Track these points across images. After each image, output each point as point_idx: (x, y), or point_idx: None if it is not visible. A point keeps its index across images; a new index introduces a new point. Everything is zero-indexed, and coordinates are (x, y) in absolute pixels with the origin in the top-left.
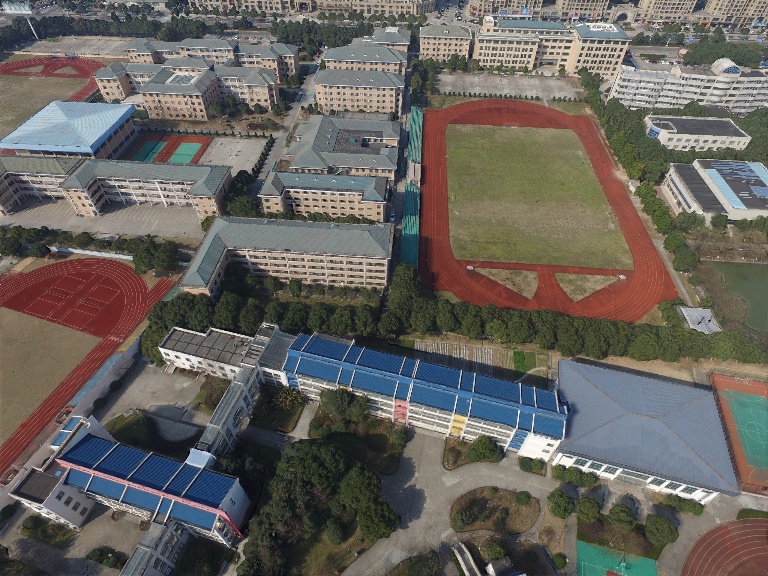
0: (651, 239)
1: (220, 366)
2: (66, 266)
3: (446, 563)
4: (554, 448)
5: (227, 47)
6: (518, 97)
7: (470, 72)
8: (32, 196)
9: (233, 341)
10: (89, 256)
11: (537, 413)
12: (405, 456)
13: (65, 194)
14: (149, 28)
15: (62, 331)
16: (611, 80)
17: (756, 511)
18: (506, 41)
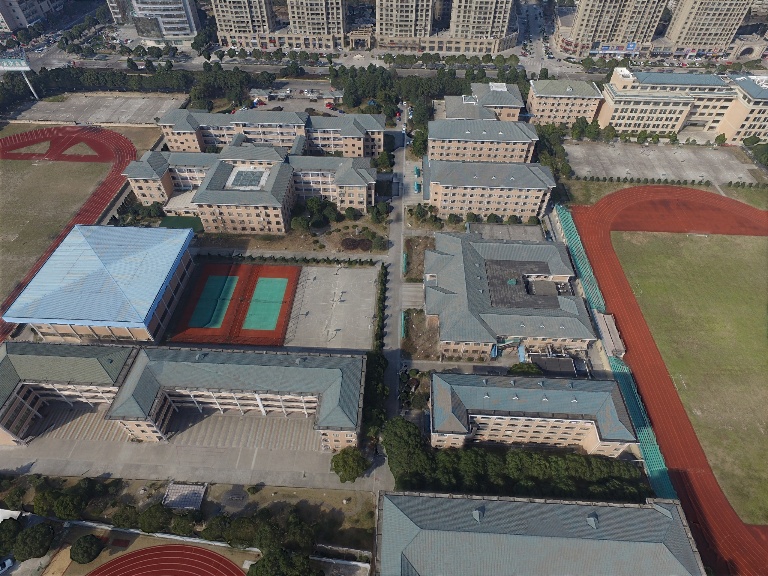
0: None
1: None
2: (130, 568)
3: None
4: None
5: (297, 122)
6: (680, 181)
7: (600, 140)
8: None
9: None
10: (164, 541)
11: None
12: None
13: None
14: (179, 83)
15: None
16: None
17: None
18: (650, 102)
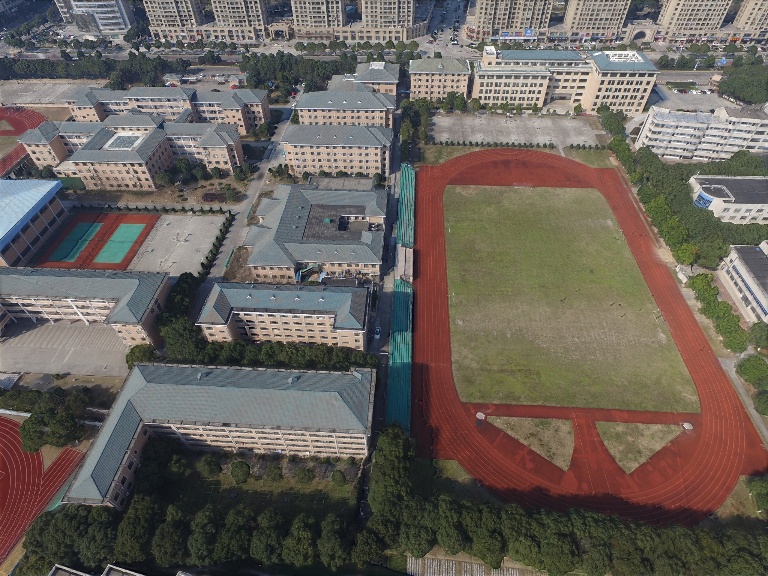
0: (717, 358)
1: None
2: None
3: None
4: None
5: (182, 96)
6: (528, 145)
7: (470, 112)
8: None
9: None
10: None
11: None
12: None
13: None
14: (100, 69)
15: None
16: (636, 117)
17: None
18: (511, 76)
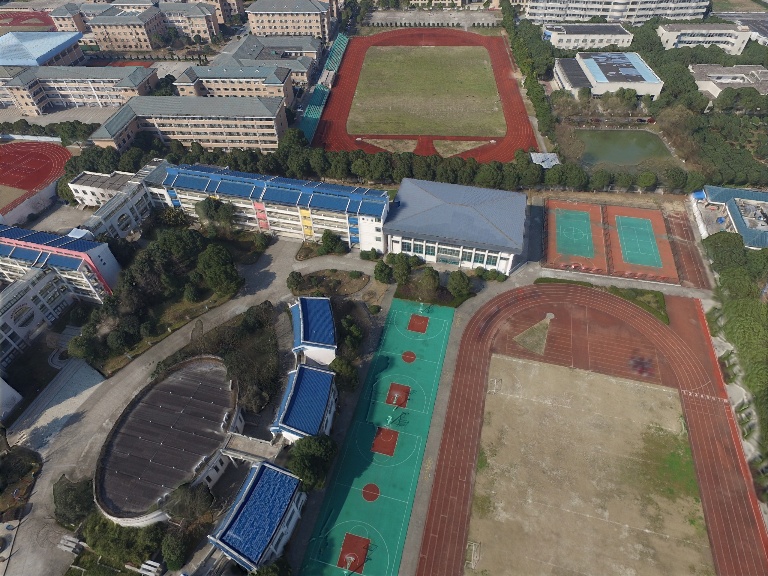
0: (528, 116)
1: None
2: (7, 147)
3: (280, 313)
4: (382, 232)
5: None
6: (441, 25)
7: (402, 9)
8: None
9: None
10: (28, 141)
11: (364, 200)
12: (266, 254)
13: None
14: None
15: None
16: None
17: (551, 278)
18: None
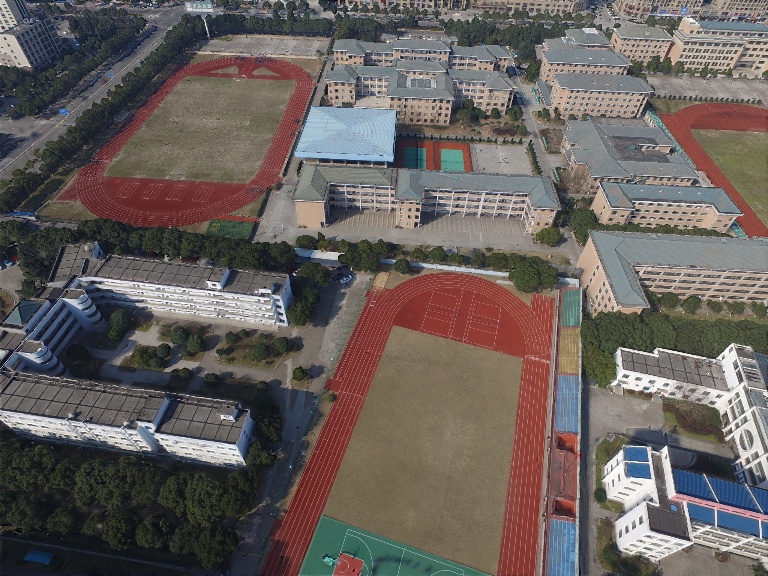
0: None
1: (693, 388)
2: (426, 281)
3: None
4: None
5: (445, 49)
6: None
7: (671, 74)
8: (335, 207)
9: (688, 362)
10: (442, 271)
11: None
12: None
13: None
14: (325, 27)
15: (476, 351)
16: None
17: None
18: (712, 43)
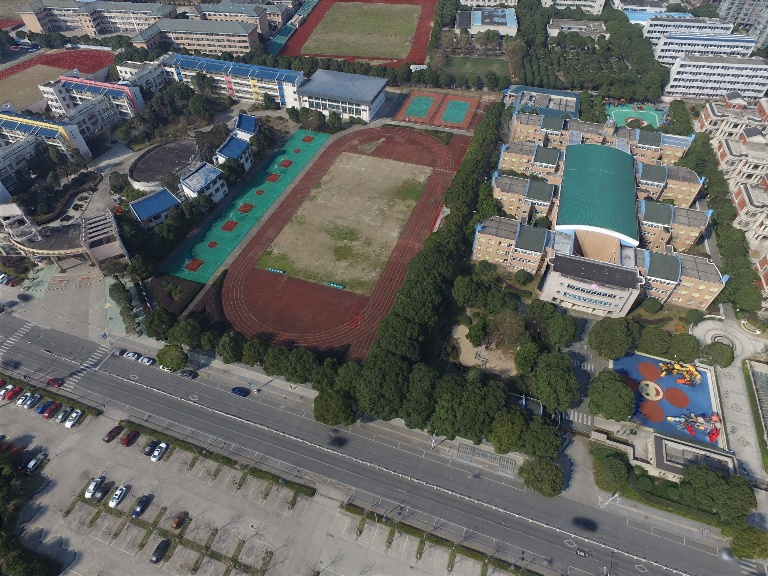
0: None
1: None
2: (75, 52)
3: None
4: None
5: None
6: None
7: None
8: (59, 27)
9: None
10: (89, 49)
11: (287, 74)
12: (231, 108)
13: (78, 23)
14: None
15: None
16: None
17: (392, 124)
18: None
